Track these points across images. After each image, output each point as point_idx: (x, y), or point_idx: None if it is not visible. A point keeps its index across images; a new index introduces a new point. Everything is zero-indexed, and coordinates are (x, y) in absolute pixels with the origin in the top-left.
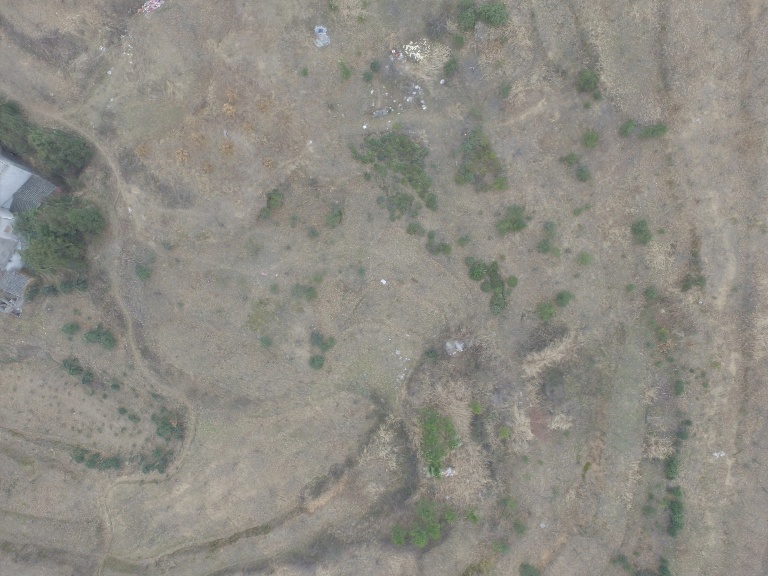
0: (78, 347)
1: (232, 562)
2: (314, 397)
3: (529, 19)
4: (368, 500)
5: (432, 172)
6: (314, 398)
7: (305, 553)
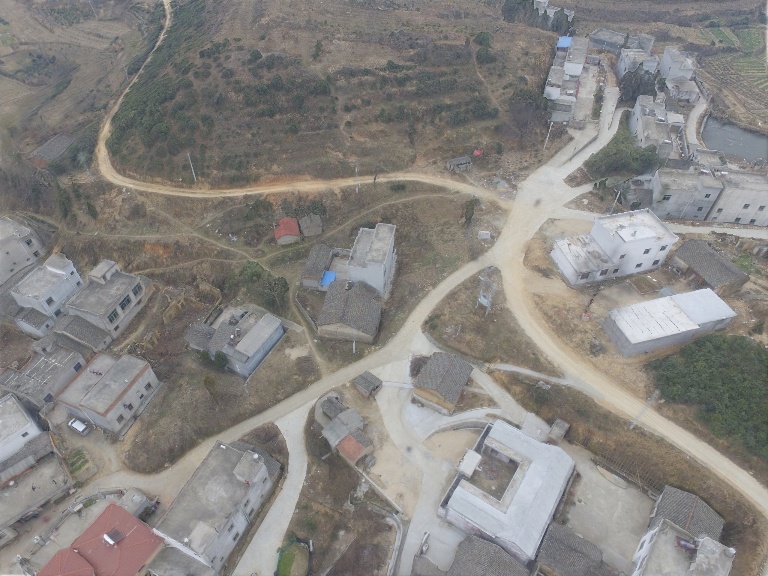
0: None
1: None
2: None
3: (342, 1)
4: None
5: (382, 4)
6: None
7: None
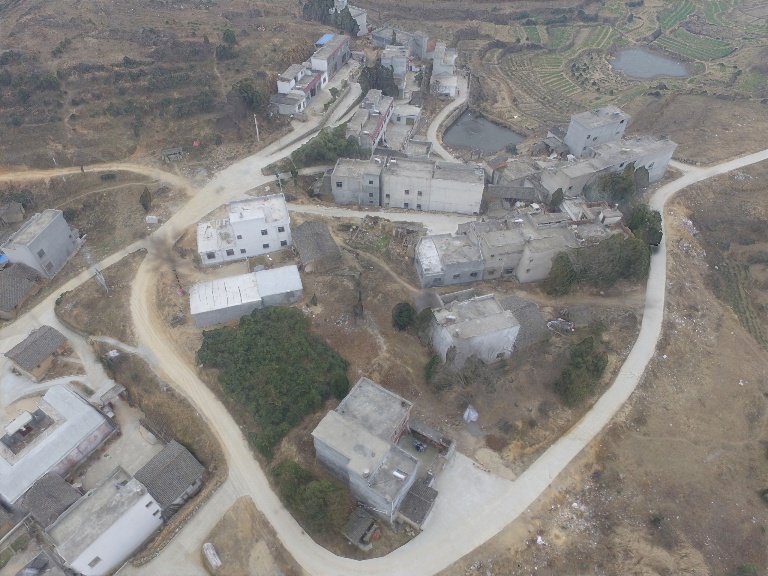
0: None
1: None
2: None
3: (144, 0)
4: None
5: None
6: None
7: None
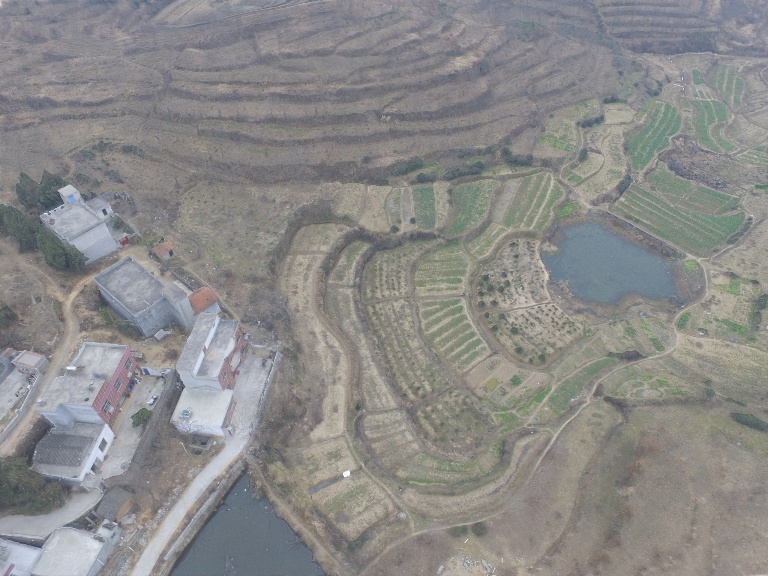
0: (101, 179)
1: (85, 108)
2: (1, 150)
3: None
4: (6, 115)
5: None
6: (1, 150)
7: (45, 103)
